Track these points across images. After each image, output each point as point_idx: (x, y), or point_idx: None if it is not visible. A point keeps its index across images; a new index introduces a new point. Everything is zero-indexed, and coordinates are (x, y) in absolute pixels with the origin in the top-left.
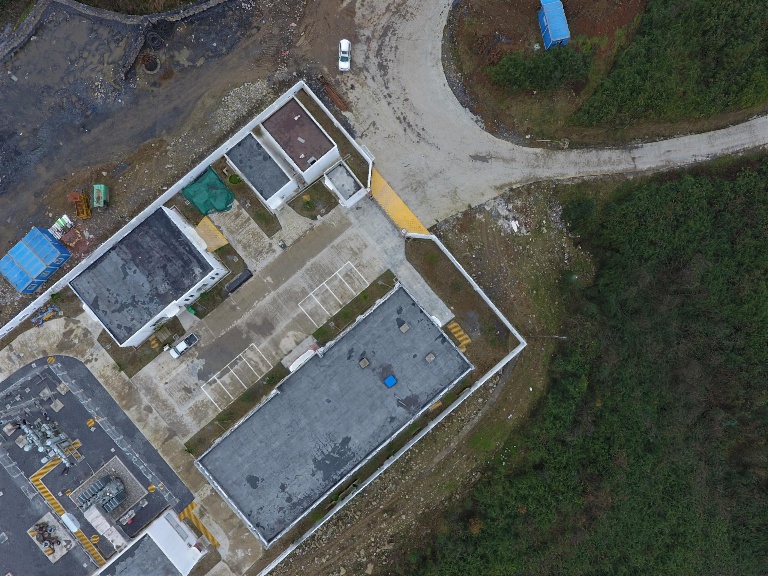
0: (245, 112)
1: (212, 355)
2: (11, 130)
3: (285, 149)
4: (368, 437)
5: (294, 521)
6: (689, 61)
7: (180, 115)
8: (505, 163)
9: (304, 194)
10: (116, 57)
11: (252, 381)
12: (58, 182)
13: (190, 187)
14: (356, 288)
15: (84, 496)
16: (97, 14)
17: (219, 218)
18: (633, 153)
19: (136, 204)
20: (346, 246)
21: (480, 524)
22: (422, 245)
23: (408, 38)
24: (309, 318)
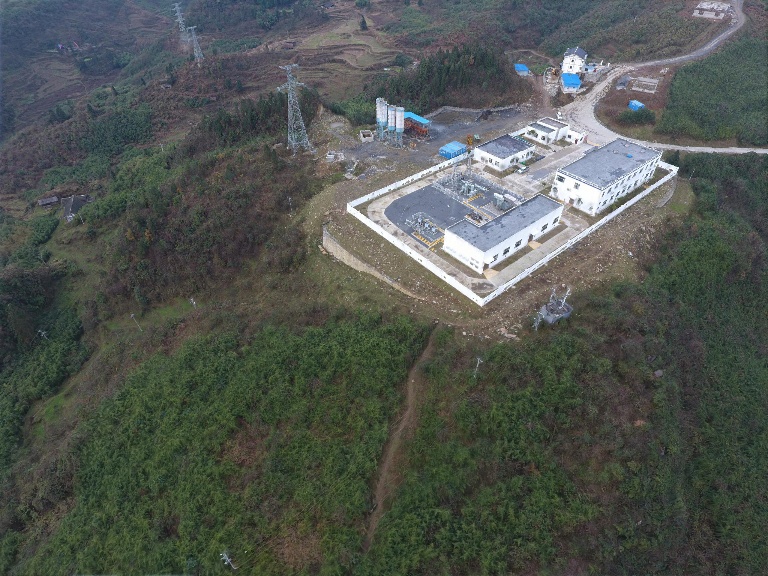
0: None
1: (536, 174)
2: (434, 129)
3: None
4: None
5: None
6: (691, 121)
7: (501, 126)
8: None
9: (557, 142)
10: None
11: None
12: (456, 138)
13: None
14: None
15: None
16: (464, 110)
17: None
18: (685, 147)
19: None
20: (581, 152)
21: None
22: None
23: None
24: None
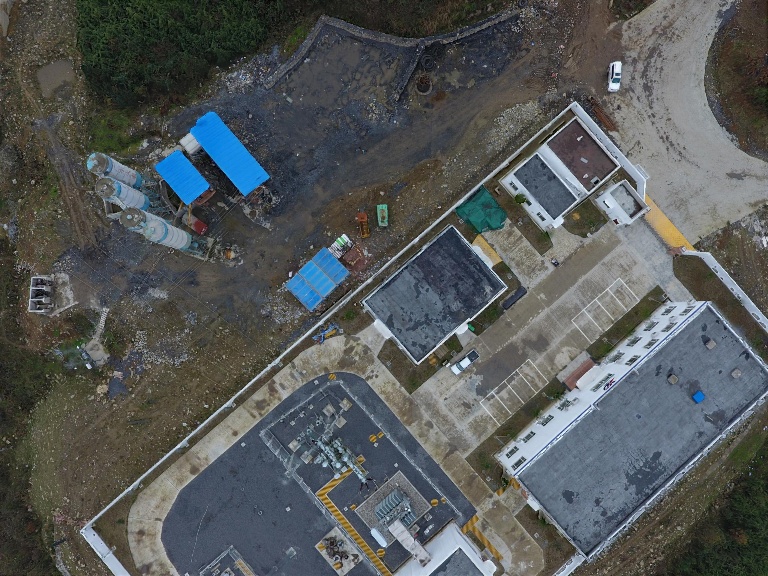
0: (517, 132)
1: (489, 371)
2: (288, 151)
3: (569, 169)
4: (678, 452)
5: (611, 535)
6: None
7: (454, 135)
8: (758, 180)
9: (574, 212)
10: (388, 79)
11: (529, 396)
12: (335, 202)
13: (465, 206)
14: (627, 304)
15: (382, 511)
16: (372, 37)
17: (492, 236)
18: None
19: (413, 223)
20: (616, 263)
21: (744, 534)
22: (689, 261)
23: (673, 59)
24: (582, 334)
